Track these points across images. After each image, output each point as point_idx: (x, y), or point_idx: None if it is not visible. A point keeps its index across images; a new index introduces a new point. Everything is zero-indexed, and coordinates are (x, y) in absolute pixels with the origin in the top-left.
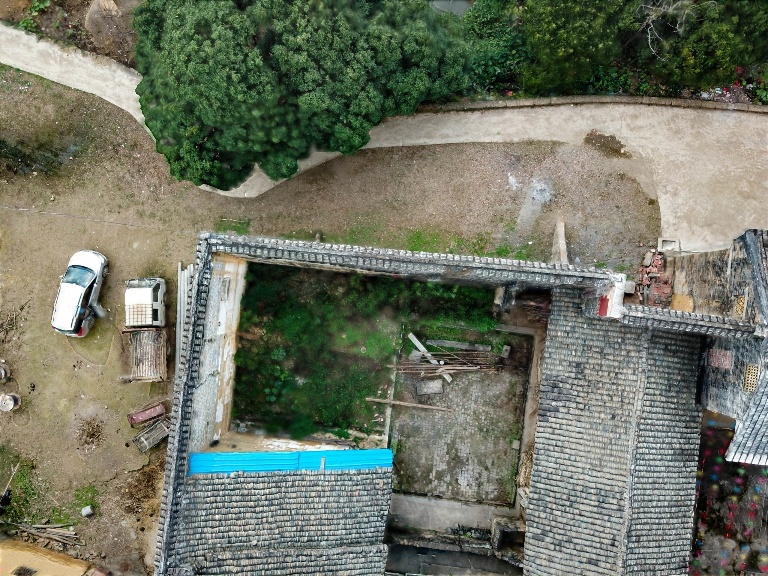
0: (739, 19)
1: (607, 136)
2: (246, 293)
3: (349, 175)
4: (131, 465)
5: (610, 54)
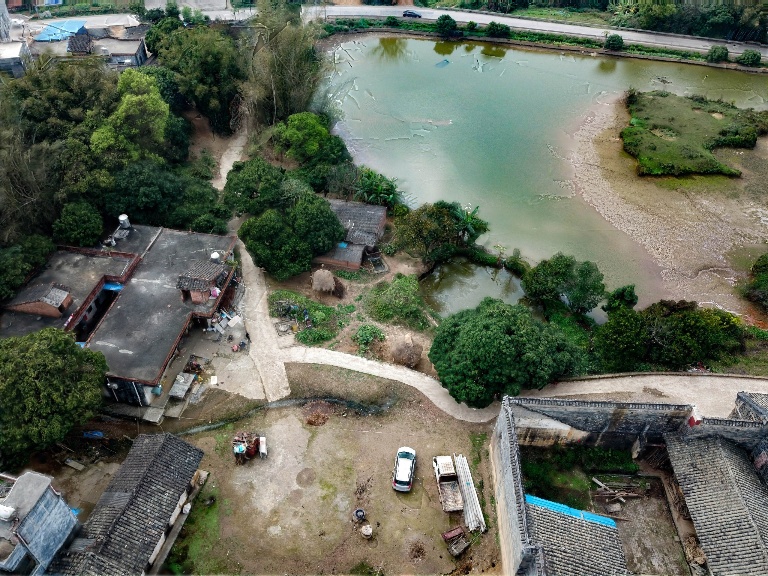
0: (690, 335)
1: (653, 389)
2: None
3: None
4: (445, 570)
5: (641, 350)
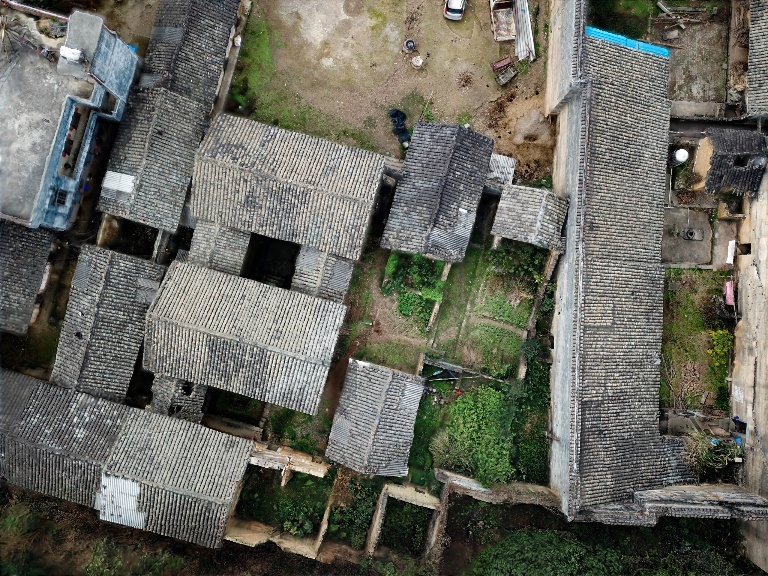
0: None
1: None
2: None
3: None
4: (491, 98)
5: None
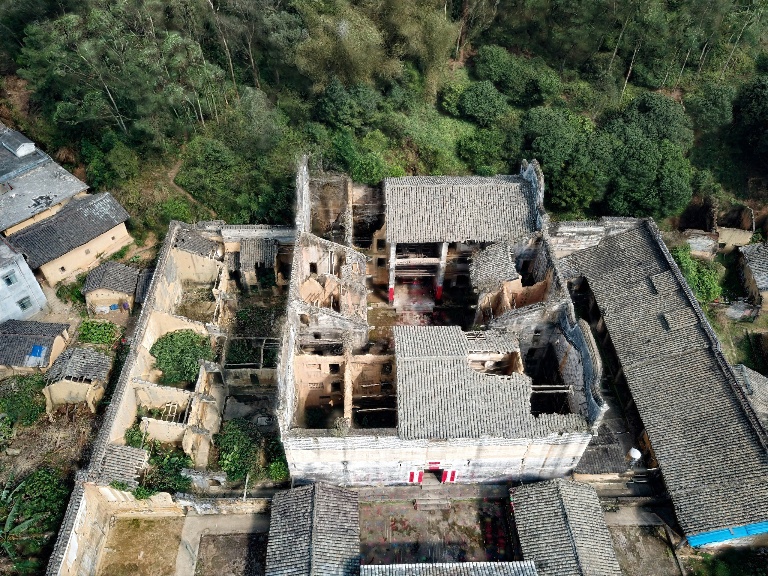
0: None
1: None
2: None
3: None
4: None
5: None
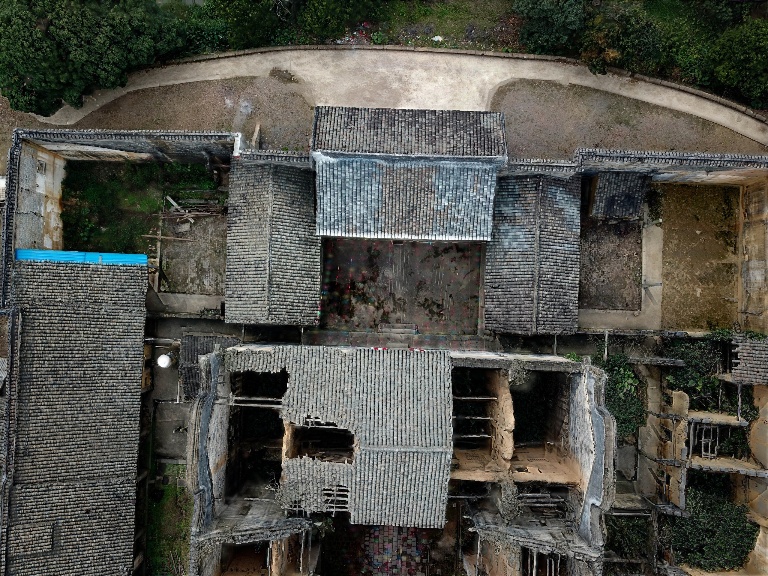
0: None
1: (283, 71)
2: (66, 178)
3: (129, 106)
4: None
5: (265, 20)
